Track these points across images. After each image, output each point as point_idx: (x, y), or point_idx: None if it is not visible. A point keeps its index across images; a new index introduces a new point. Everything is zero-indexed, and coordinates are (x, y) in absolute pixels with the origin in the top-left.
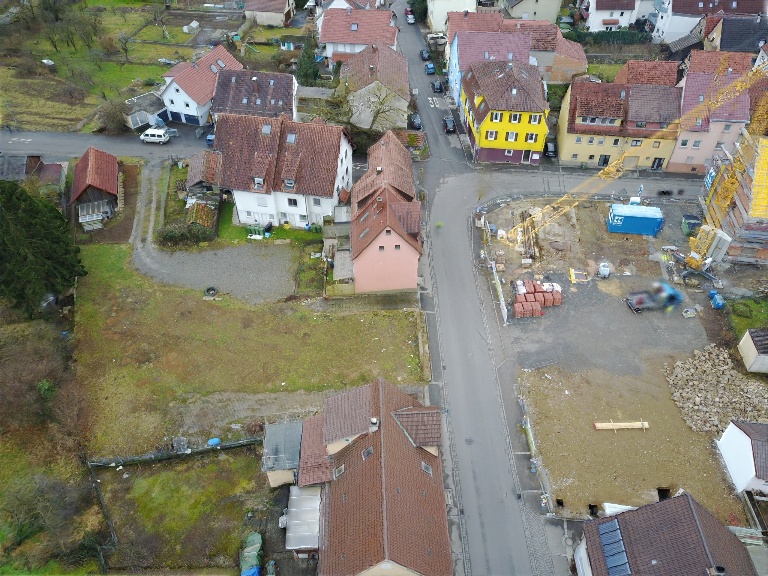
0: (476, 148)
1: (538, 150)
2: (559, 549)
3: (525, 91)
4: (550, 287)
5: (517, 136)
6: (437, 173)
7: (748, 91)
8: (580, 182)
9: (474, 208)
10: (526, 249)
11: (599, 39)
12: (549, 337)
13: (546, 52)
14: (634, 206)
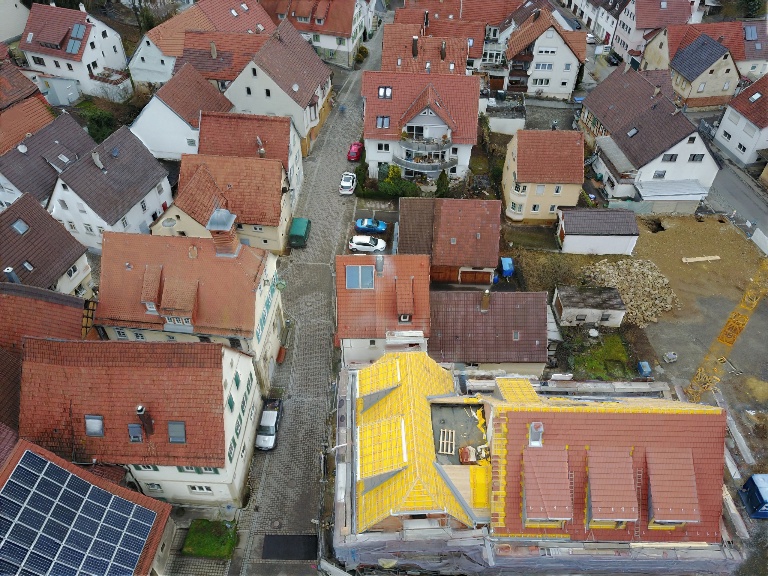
0: None
1: None
2: (713, 202)
3: None
4: None
5: None
6: None
7: None
8: None
9: None
10: None
11: None
12: None
13: None
14: None
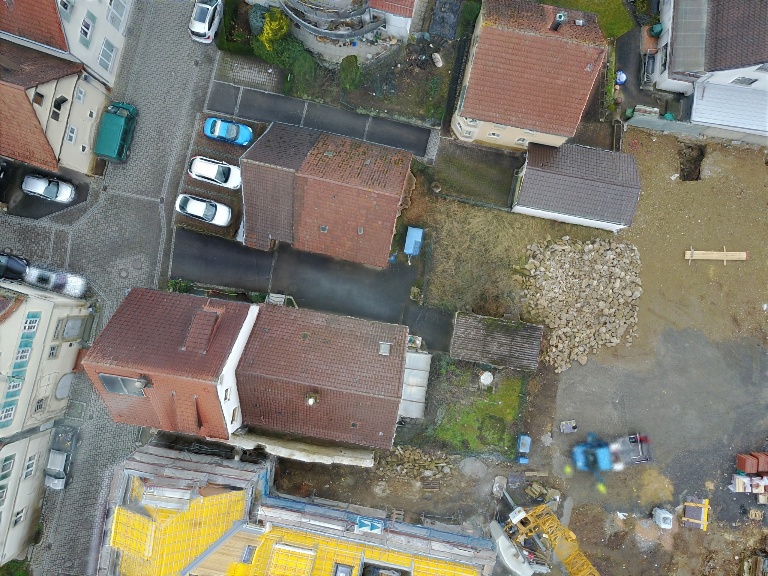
0: None
1: None
2: None
3: None
4: (758, 482)
5: None
6: None
7: None
8: None
9: None
10: None
11: None
12: (766, 397)
13: None
14: None
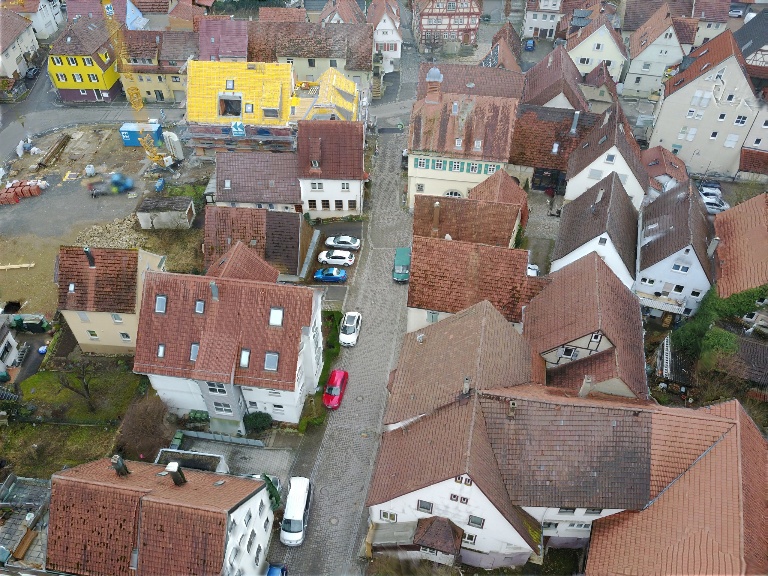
0: (55, 89)
1: (104, 89)
2: None
3: (78, 39)
4: (33, 182)
5: (82, 77)
6: (21, 111)
7: (247, 33)
8: (135, 113)
9: (31, 134)
10: (41, 159)
11: (241, 6)
12: (11, 216)
13: (160, 14)
14: (141, 124)
